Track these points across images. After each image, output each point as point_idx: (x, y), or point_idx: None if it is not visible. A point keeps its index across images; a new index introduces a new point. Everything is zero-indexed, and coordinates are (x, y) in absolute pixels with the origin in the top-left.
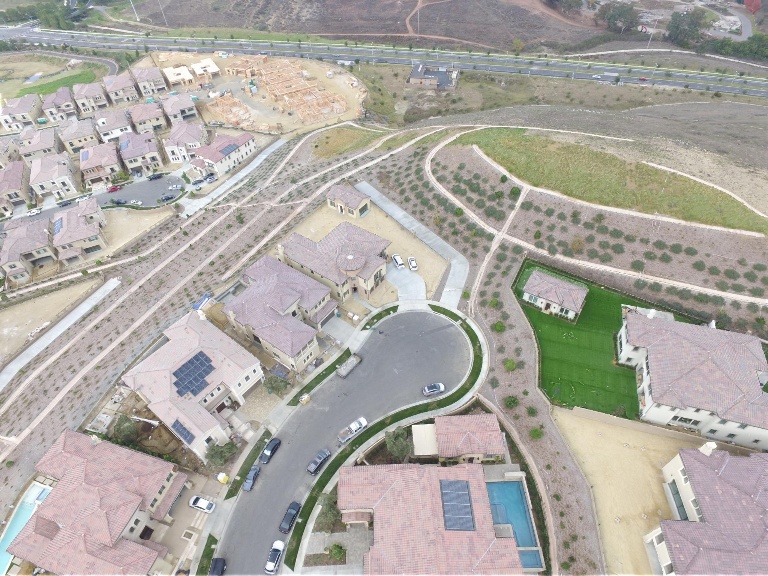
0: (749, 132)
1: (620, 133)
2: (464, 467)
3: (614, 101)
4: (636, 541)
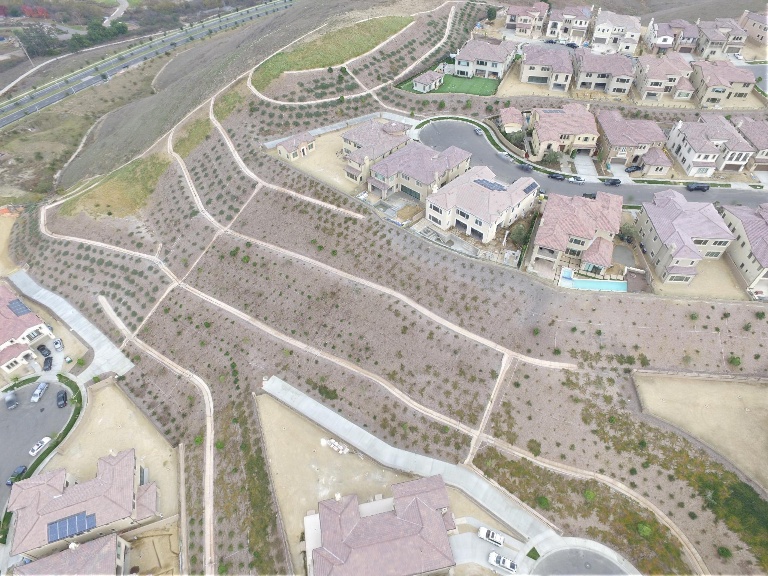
0: (330, 5)
1: (315, 26)
2: (535, 110)
3: (135, 86)
4: (551, 92)
